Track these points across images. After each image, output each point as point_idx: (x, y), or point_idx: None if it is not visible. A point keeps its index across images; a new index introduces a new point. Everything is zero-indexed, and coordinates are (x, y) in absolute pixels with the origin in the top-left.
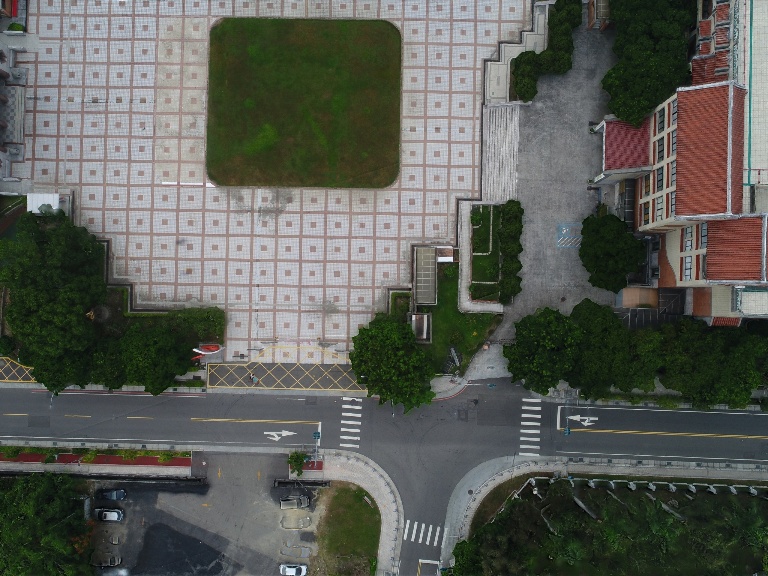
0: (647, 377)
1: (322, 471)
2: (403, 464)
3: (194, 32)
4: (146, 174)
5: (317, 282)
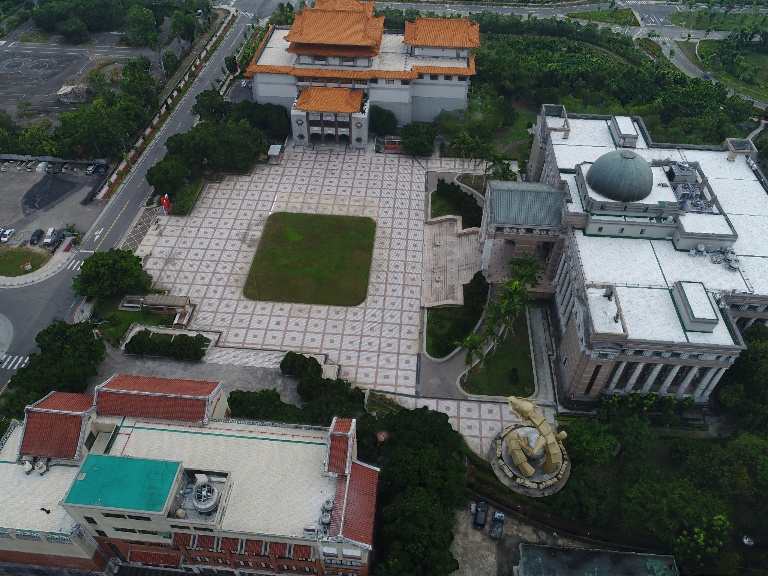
0: (8, 400)
1: (62, 251)
2: (41, 290)
3: (368, 211)
4: (284, 190)
5: (190, 256)
